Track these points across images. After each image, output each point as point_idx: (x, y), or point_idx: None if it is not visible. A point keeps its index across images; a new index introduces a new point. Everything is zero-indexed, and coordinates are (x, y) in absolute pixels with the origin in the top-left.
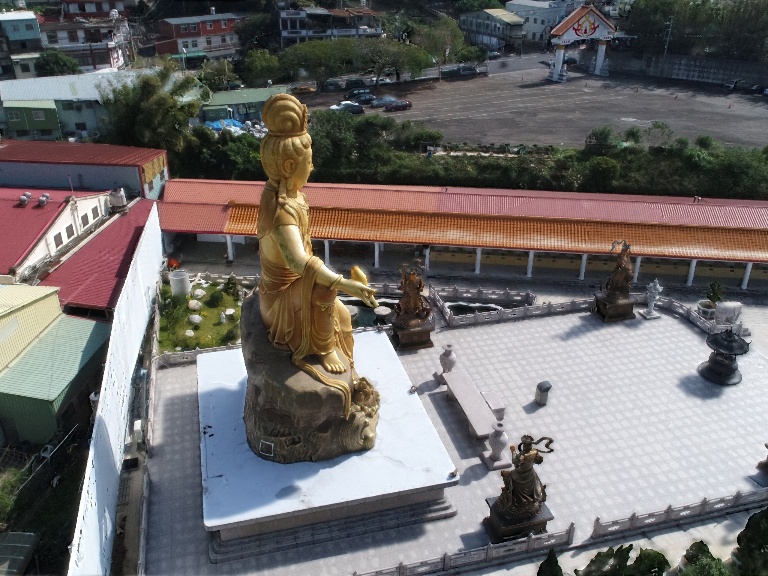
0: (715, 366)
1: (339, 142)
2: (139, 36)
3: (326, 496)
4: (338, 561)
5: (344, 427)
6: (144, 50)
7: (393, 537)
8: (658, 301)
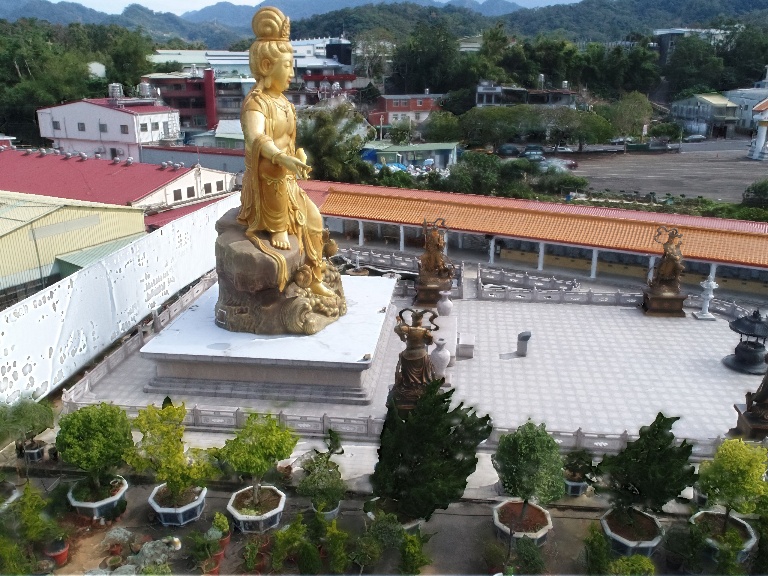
0: (738, 352)
1: (481, 181)
2: (360, 110)
3: (246, 352)
4: None
5: (285, 305)
6: None
7: (300, 407)
8: (721, 307)
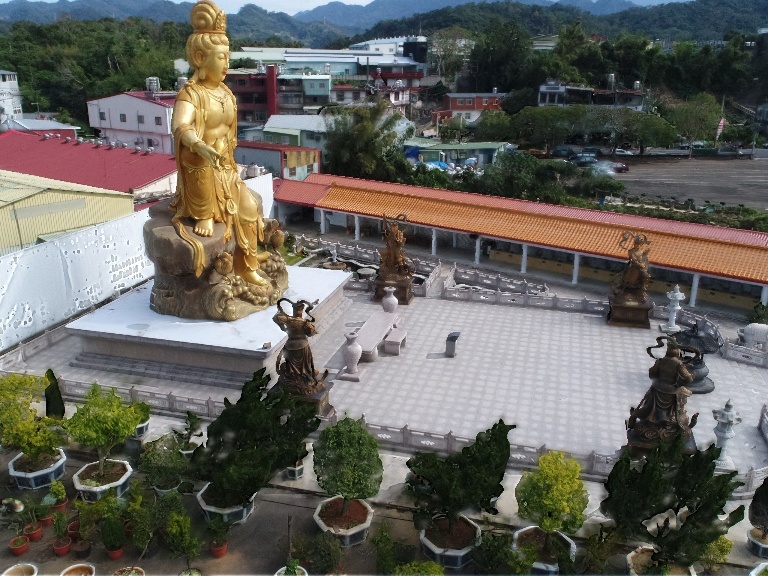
0: None
1: None
2: (426, 108)
3: (158, 334)
4: (146, 389)
5: (206, 291)
6: (426, 119)
7: (202, 390)
8: (692, 320)
